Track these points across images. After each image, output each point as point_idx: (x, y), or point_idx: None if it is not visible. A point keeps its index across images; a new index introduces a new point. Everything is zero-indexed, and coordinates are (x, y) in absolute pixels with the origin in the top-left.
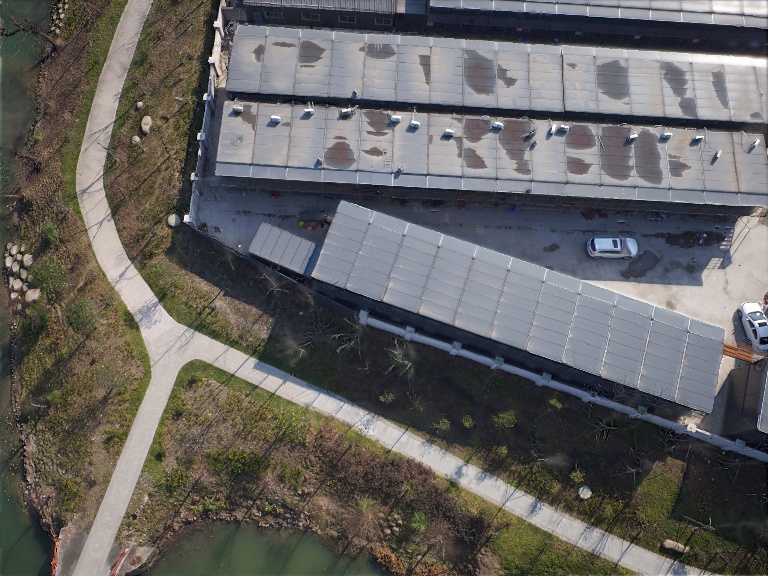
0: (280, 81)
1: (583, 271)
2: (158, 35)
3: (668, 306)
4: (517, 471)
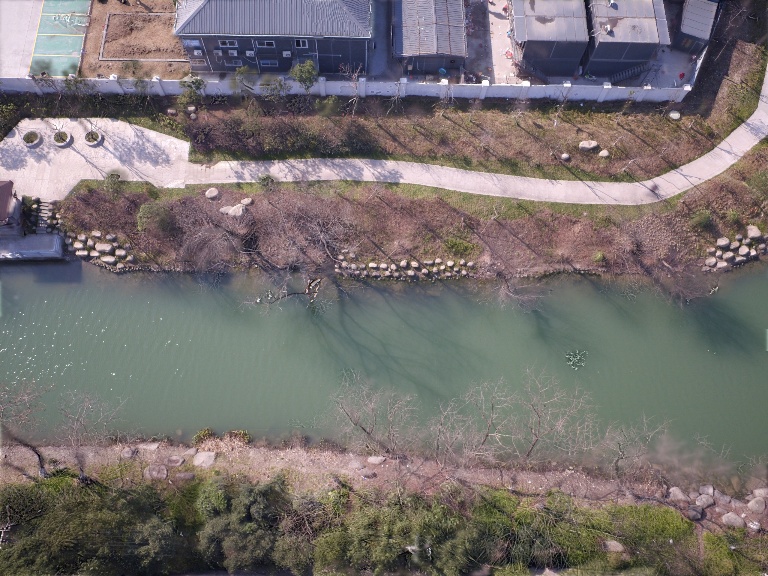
0: (571, 3)
1: None
2: (484, 151)
3: None
4: None
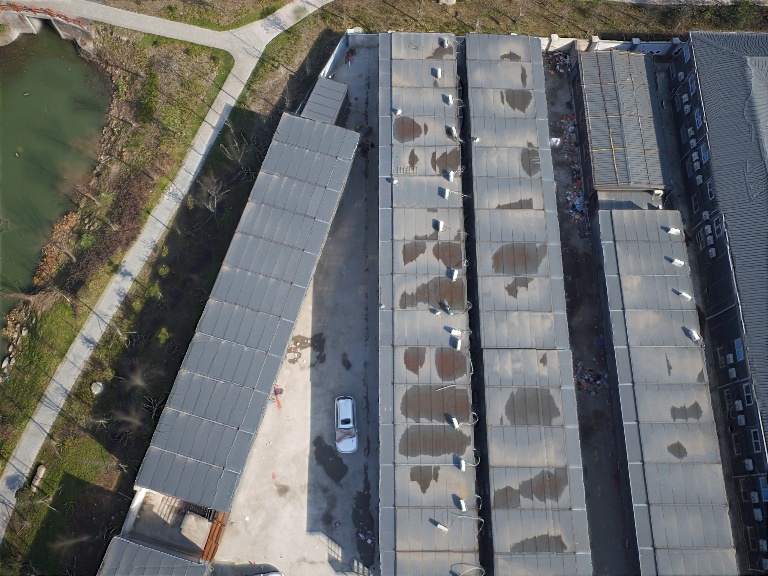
0: (482, 76)
1: (321, 394)
2: (545, 2)
3: (283, 487)
4: (123, 324)
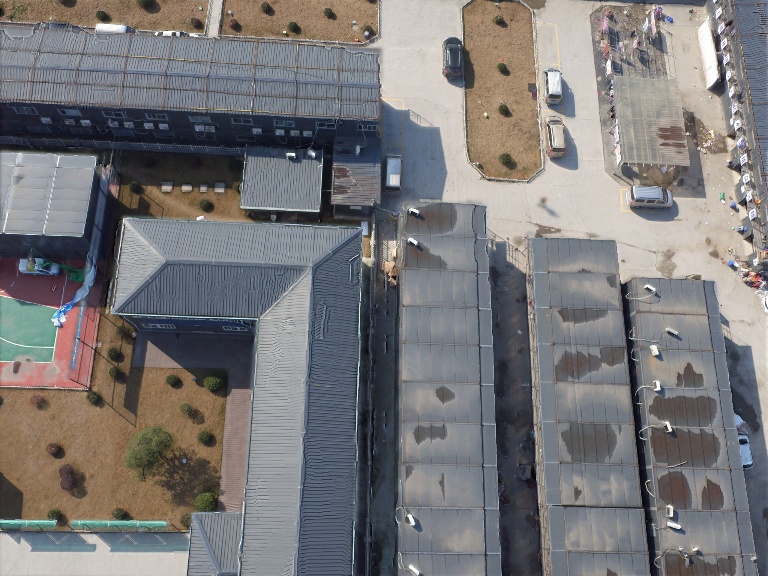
0: None
1: (761, 474)
2: None
3: None
4: None
